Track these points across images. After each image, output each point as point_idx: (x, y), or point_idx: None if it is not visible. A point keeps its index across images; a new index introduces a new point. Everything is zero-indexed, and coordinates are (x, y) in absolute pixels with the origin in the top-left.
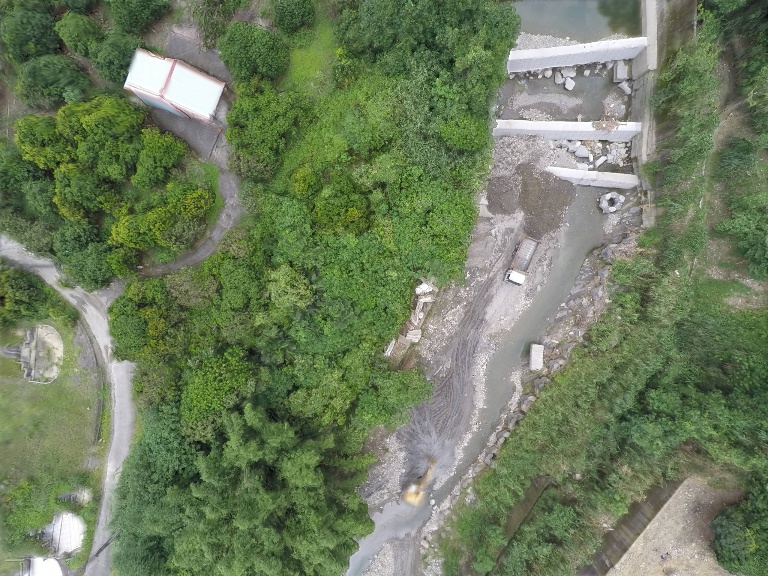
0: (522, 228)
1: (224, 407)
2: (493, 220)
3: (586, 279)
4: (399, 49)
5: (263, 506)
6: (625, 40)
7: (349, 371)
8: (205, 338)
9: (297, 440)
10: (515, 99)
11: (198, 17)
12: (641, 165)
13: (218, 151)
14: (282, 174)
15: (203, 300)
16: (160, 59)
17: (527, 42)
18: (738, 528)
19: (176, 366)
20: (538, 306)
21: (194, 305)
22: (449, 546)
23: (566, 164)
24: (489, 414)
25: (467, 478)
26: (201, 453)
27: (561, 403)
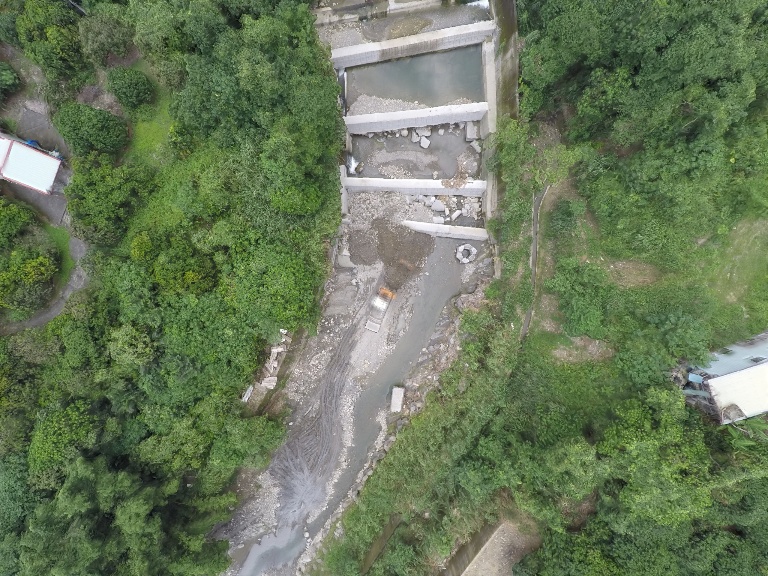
0: (383, 278)
1: (66, 458)
2: (356, 270)
3: (444, 326)
4: (223, 128)
5: (81, 555)
6: (467, 105)
7: (201, 418)
8: (54, 392)
9: (136, 488)
10: (374, 156)
11: (43, 97)
12: (487, 221)
13: (68, 218)
14: (128, 239)
15: (49, 358)
16: (1, 139)
17: (377, 106)
18: (527, 575)
19: (24, 419)
20: (402, 350)
21: (41, 362)
22: None
23: (423, 218)
24: (357, 452)
25: (337, 513)
26: (45, 500)
27: (413, 445)
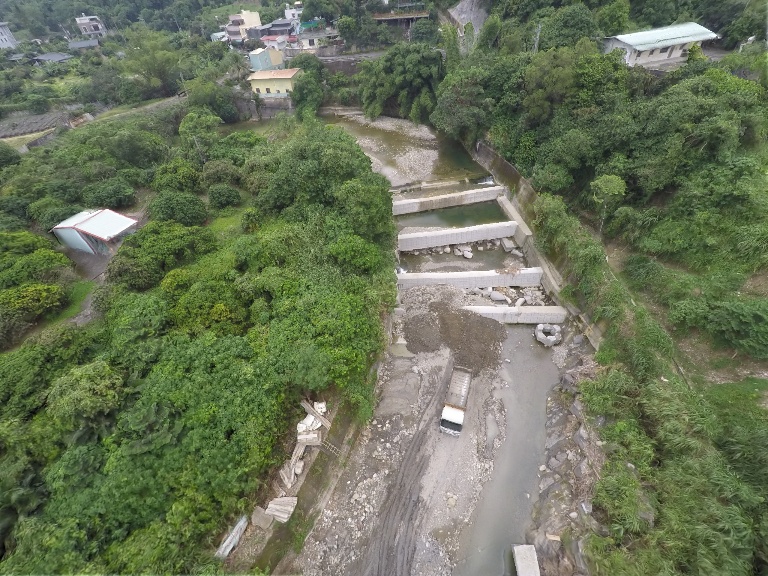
0: (452, 365)
1: None
2: (415, 359)
3: (559, 423)
4: None
5: None
6: (499, 223)
7: None
8: None
9: None
10: (422, 266)
11: (147, 203)
12: (558, 294)
13: None
14: None
15: None
16: None
17: (421, 230)
18: None
19: None
20: (505, 474)
21: None
22: None
23: (484, 305)
24: None
25: None
26: None
27: None
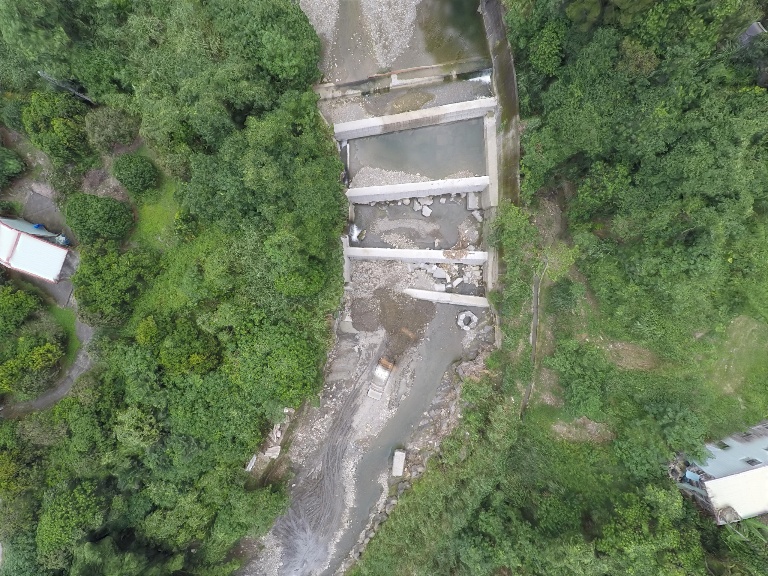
0: (384, 344)
1: (73, 539)
2: (358, 336)
3: (445, 391)
4: (228, 217)
5: None
6: (469, 179)
7: (206, 491)
8: None
9: (142, 567)
10: (376, 224)
11: (49, 183)
12: (488, 292)
13: (74, 299)
14: (133, 320)
15: (56, 439)
16: (9, 228)
17: (380, 178)
18: None
19: (32, 499)
20: (403, 414)
21: (48, 444)
22: None
23: (424, 285)
24: (359, 513)
25: (339, 572)
26: None
27: (414, 512)
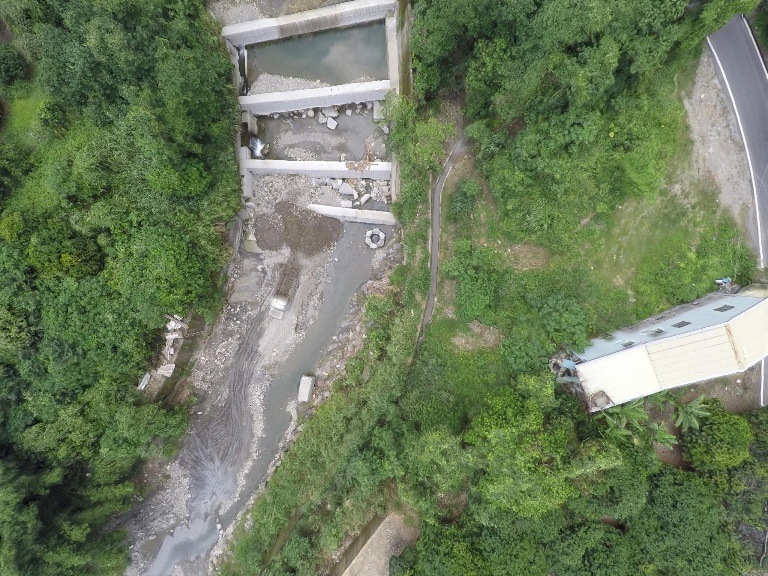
0: (290, 263)
1: None
2: (263, 255)
3: (354, 313)
4: (92, 104)
5: None
6: (369, 83)
7: (91, 406)
8: None
9: (11, 476)
10: (280, 138)
11: None
12: (392, 204)
13: None
14: None
15: None
16: None
17: (278, 85)
18: (400, 569)
19: None
20: (312, 338)
21: None
22: (231, 569)
23: (330, 201)
24: (268, 443)
25: (248, 504)
26: None
27: (316, 435)
